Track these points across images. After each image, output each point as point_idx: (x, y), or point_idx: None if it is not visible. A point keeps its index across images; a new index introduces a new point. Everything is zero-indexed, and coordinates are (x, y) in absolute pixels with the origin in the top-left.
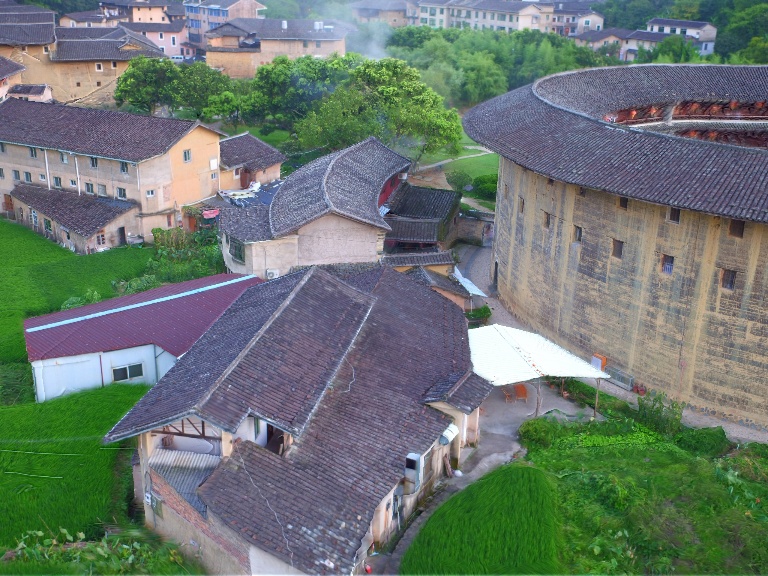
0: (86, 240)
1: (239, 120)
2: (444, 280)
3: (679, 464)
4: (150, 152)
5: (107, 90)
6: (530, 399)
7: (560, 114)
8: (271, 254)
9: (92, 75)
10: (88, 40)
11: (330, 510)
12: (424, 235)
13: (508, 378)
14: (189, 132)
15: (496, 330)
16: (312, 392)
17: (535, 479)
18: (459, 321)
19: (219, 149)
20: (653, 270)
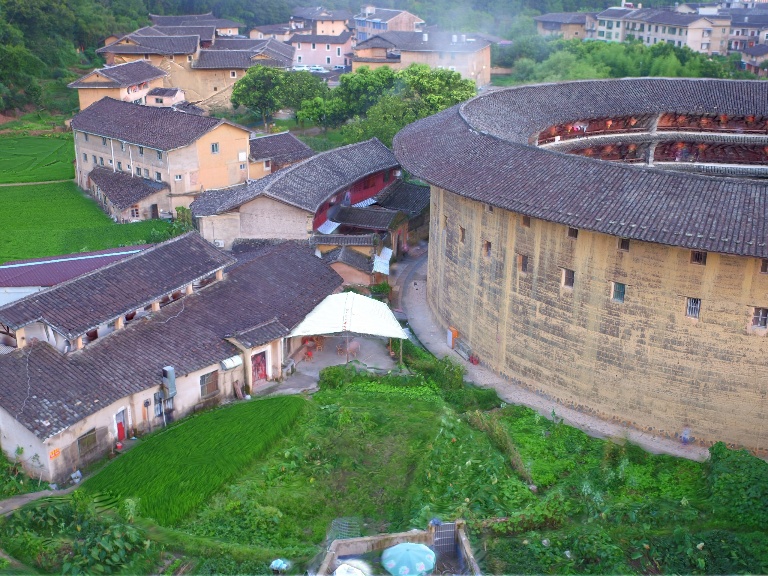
0: (121, 212)
1: (327, 123)
2: (360, 259)
3: (428, 411)
4: (178, 143)
5: (225, 94)
6: (361, 355)
7: (455, 118)
8: (218, 227)
9: (227, 81)
10: (226, 51)
11: (76, 393)
12: (380, 223)
13: (318, 330)
14: (214, 128)
15: (346, 296)
16: (108, 314)
17: (289, 404)
18: (327, 288)
19: None
20: (480, 254)
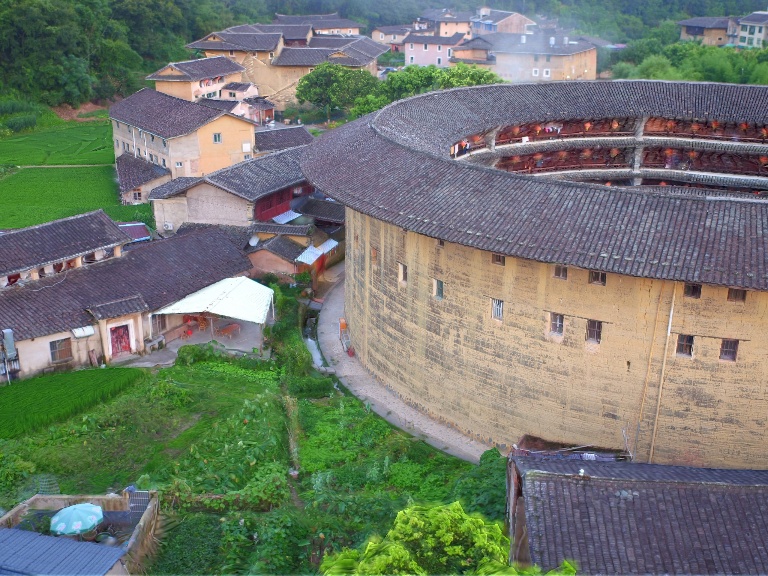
0: (124, 195)
1: None
2: (292, 248)
3: (253, 393)
4: (179, 132)
5: (292, 90)
6: (238, 337)
7: None
8: (168, 210)
9: None
10: (307, 48)
11: None
12: (338, 216)
13: (184, 309)
14: (215, 119)
15: (236, 280)
16: None
17: (123, 375)
18: (228, 272)
19: (254, 135)
20: None
